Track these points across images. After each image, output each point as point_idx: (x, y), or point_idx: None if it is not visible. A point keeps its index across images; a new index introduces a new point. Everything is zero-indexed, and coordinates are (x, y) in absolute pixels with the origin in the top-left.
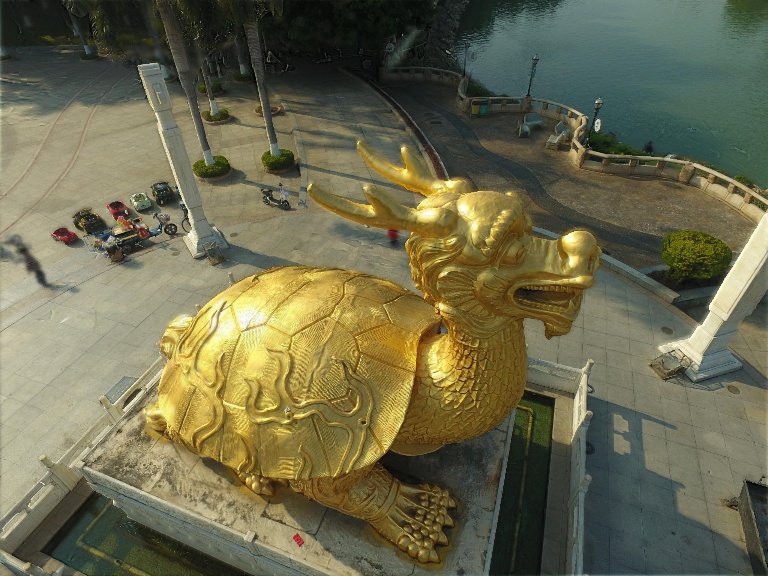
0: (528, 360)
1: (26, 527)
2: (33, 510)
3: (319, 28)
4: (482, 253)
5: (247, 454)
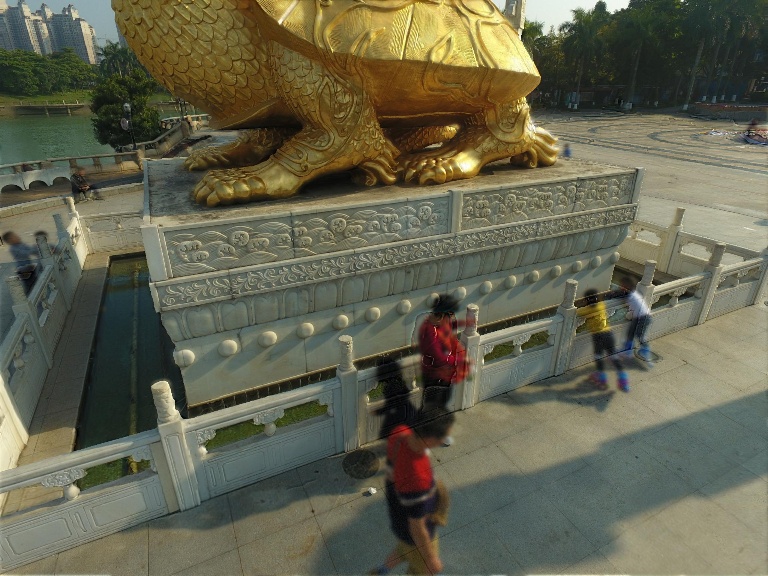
0: None
1: None
2: None
3: None
4: None
5: None
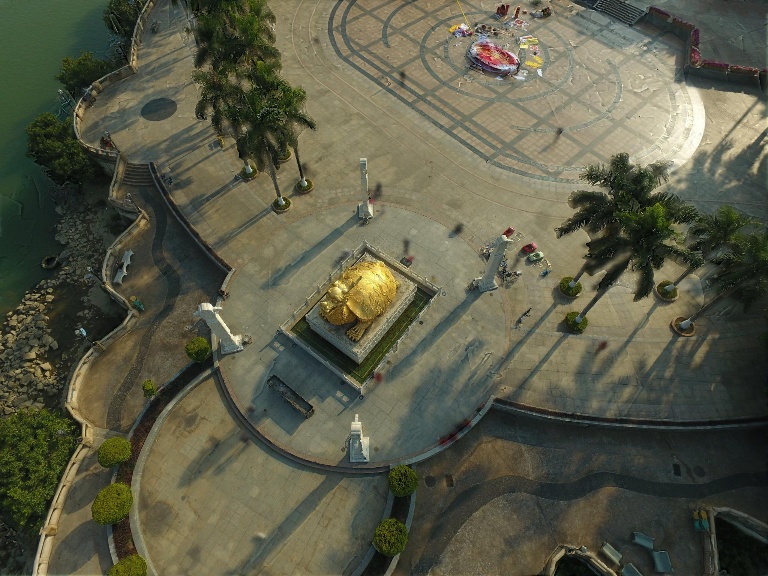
0: None
1: (369, 248)
2: (372, 249)
3: None
4: None
5: None
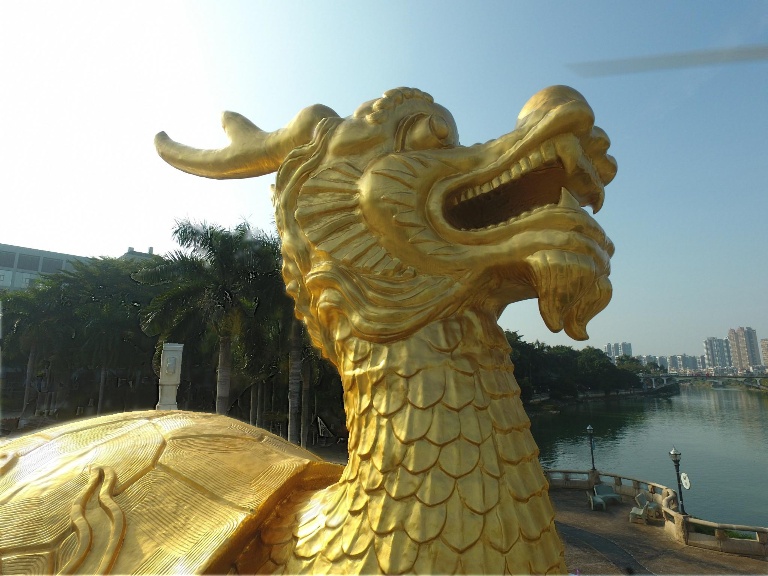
0: None
1: None
2: None
3: None
4: (367, 122)
5: None
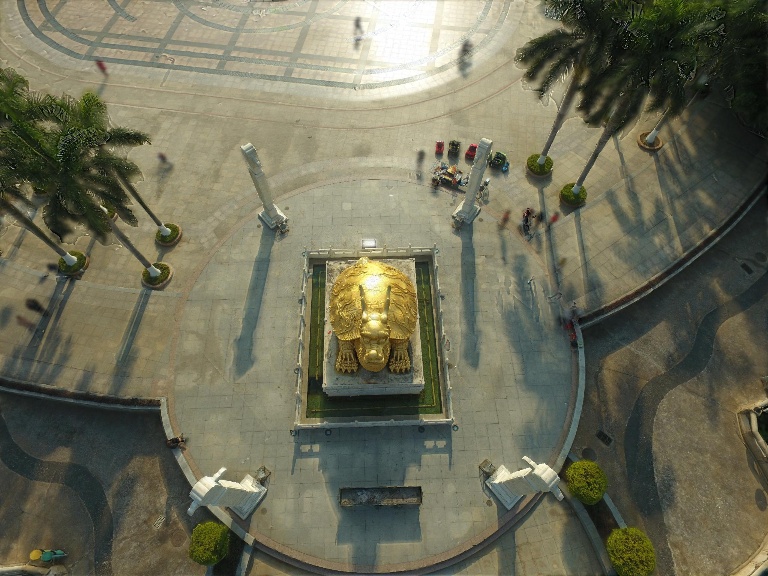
0: (449, 393)
1: (316, 256)
2: (320, 254)
3: (766, 113)
4: None
5: (332, 306)
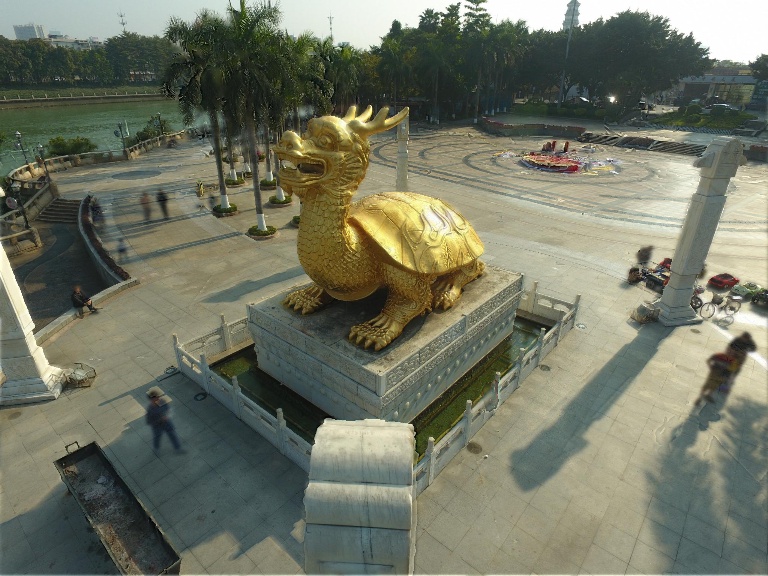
0: (424, 457)
1: None
2: None
3: None
4: None
5: None
